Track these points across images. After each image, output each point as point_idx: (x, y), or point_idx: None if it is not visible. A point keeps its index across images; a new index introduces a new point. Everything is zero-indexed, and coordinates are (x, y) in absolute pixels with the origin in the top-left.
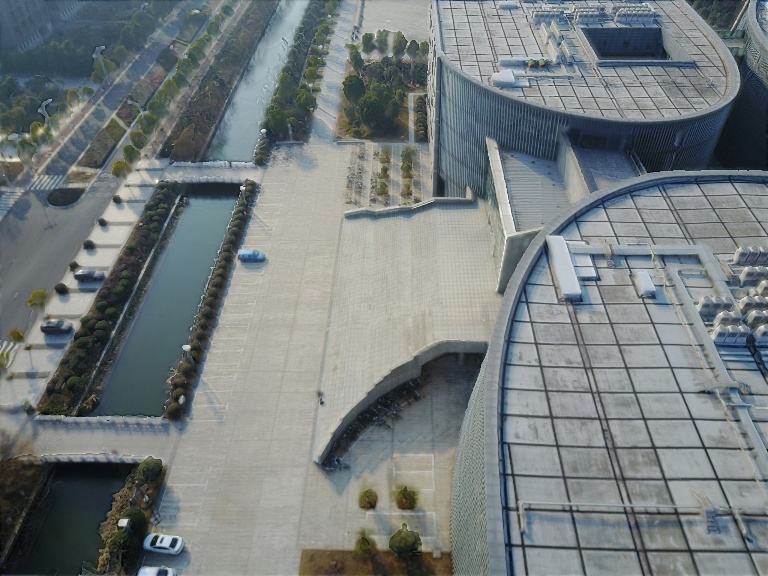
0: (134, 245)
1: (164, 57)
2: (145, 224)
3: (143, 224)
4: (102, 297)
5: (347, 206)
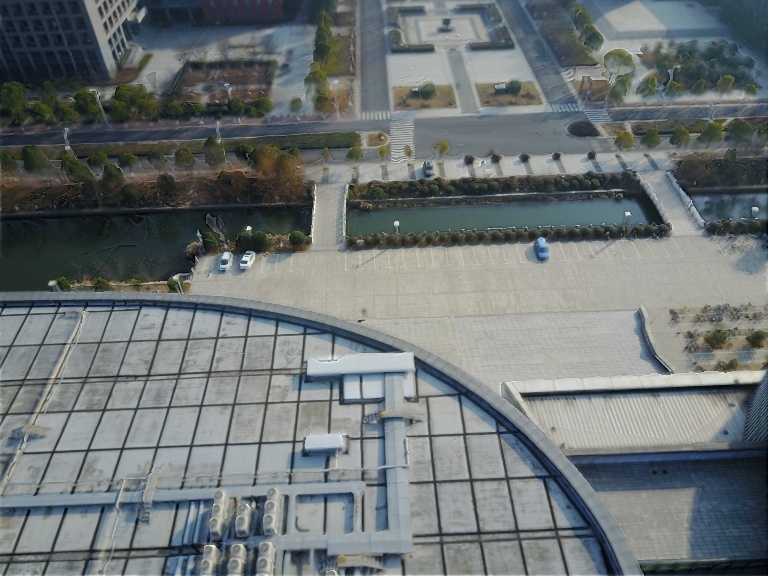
0: (531, 179)
1: None
2: (566, 179)
3: (564, 178)
4: (463, 180)
5: (665, 312)
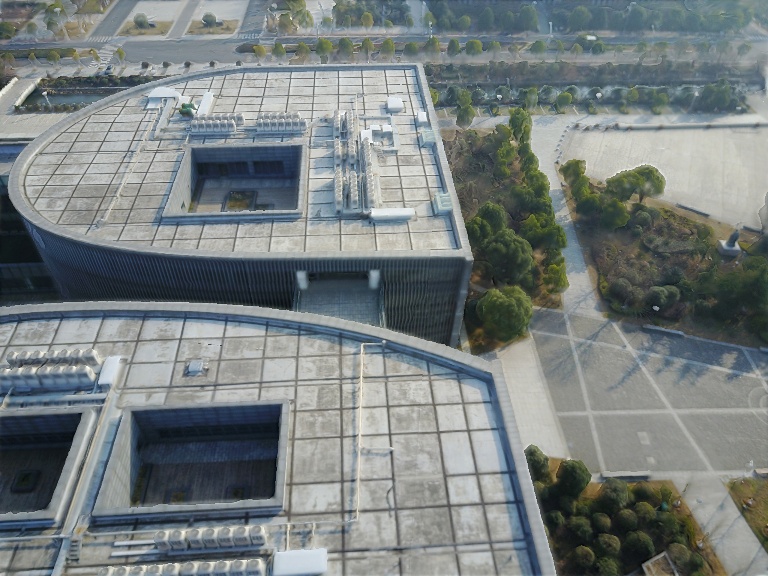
0: None
1: (483, 44)
2: None
3: None
4: (130, 76)
5: None
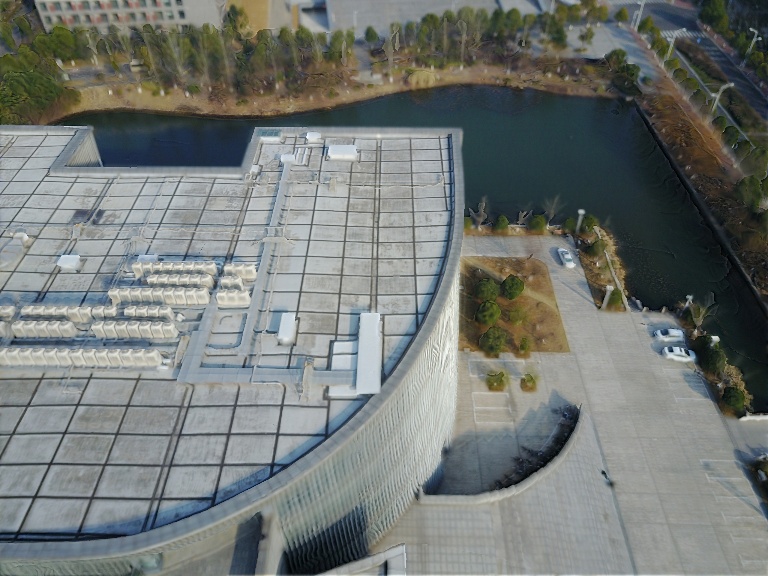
0: None
1: None
2: None
3: None
4: None
5: None
